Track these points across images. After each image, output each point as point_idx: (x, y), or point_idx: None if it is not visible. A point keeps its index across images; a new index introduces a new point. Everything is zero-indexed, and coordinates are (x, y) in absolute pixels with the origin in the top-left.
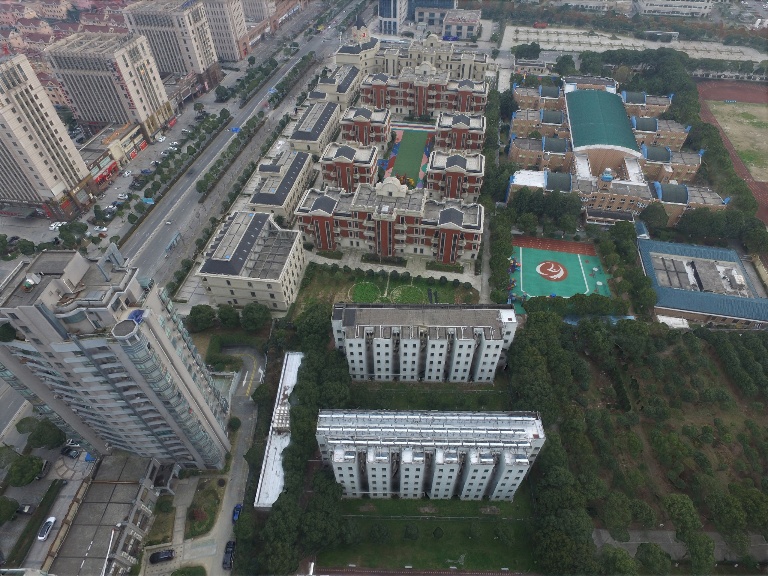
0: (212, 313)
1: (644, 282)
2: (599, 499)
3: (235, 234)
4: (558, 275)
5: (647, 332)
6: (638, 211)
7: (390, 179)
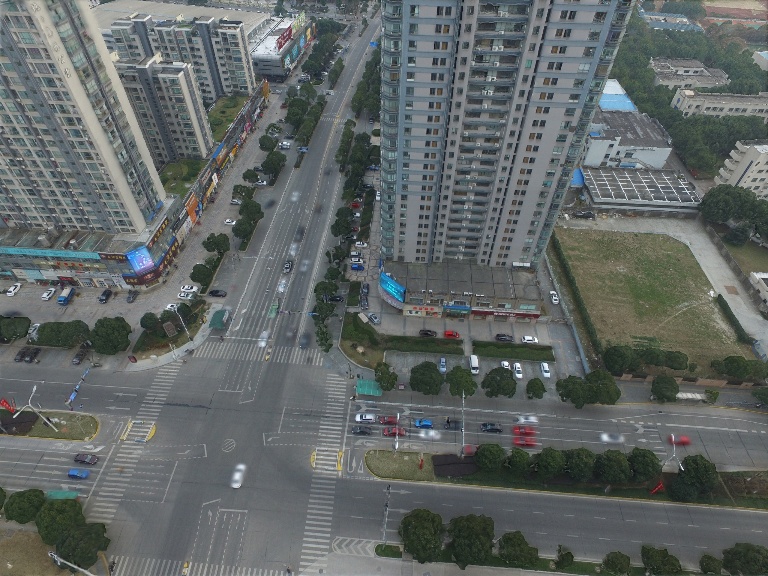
0: None
1: (640, 19)
2: None
3: None
4: None
5: (639, 23)
6: (640, 4)
7: None
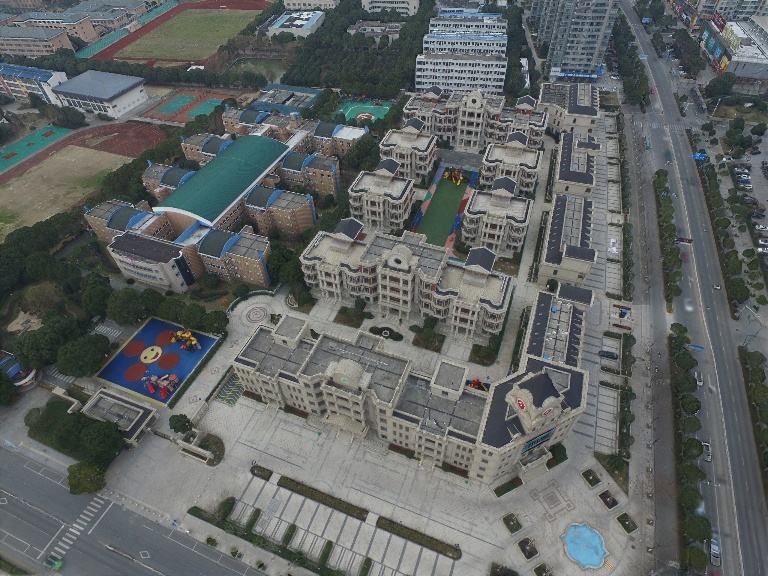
0: None
1: None
2: None
3: (584, 94)
4: (363, 114)
5: None
6: None
7: (476, 93)
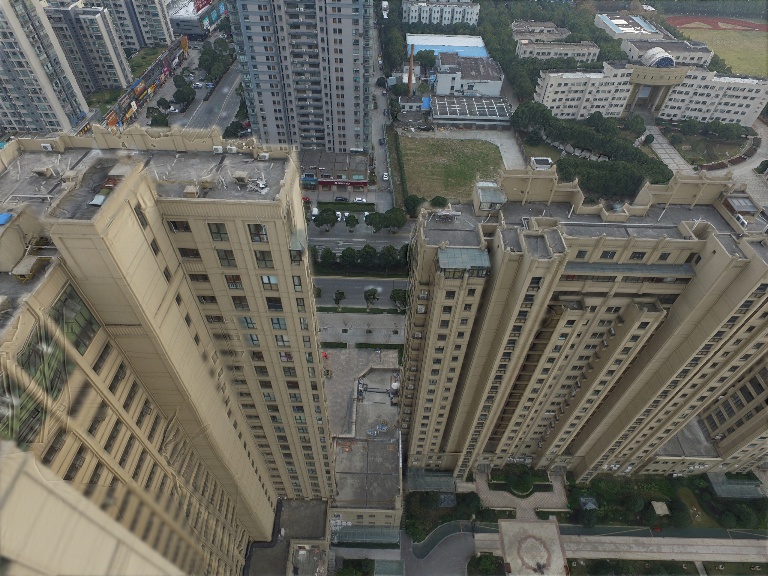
0: None
1: None
2: (489, 12)
3: None
4: None
5: None
6: None
7: None
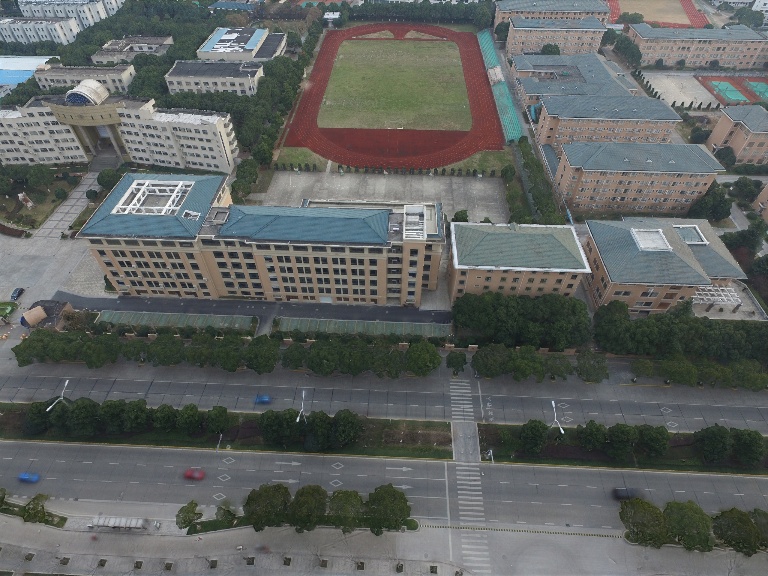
0: (12, 2)
1: None
2: None
3: None
4: None
5: (183, 3)
6: None
7: None
